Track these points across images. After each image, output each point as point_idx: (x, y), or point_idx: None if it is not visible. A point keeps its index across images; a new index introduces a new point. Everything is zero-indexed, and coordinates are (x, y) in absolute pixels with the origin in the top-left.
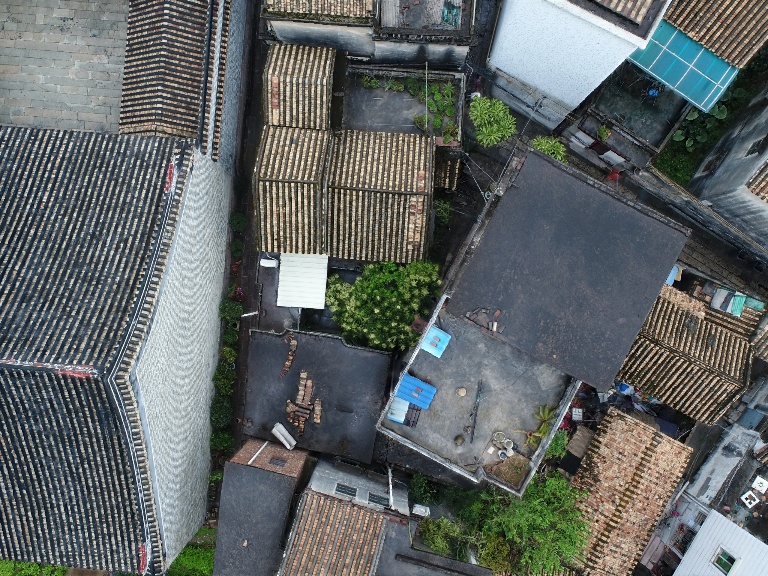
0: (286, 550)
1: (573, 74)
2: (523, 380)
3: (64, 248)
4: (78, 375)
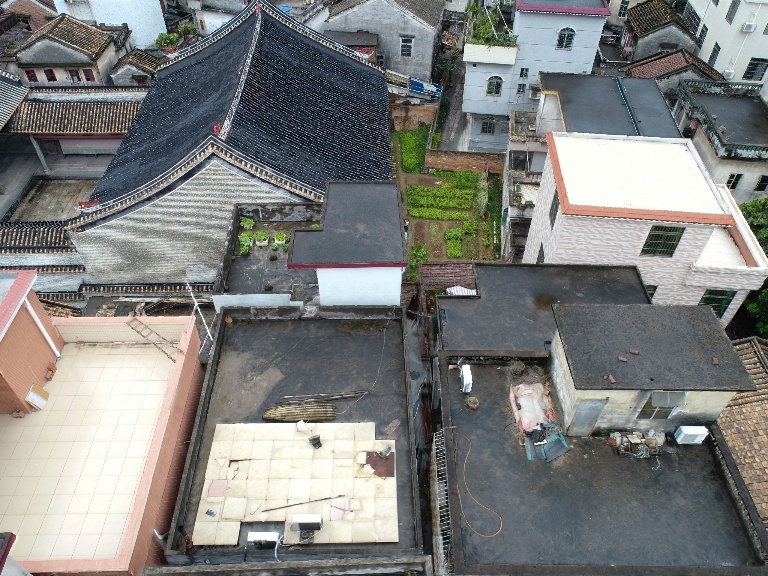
0: (348, 9)
1: (153, 8)
2: (282, 1)
3: (203, 76)
4: (257, 3)
